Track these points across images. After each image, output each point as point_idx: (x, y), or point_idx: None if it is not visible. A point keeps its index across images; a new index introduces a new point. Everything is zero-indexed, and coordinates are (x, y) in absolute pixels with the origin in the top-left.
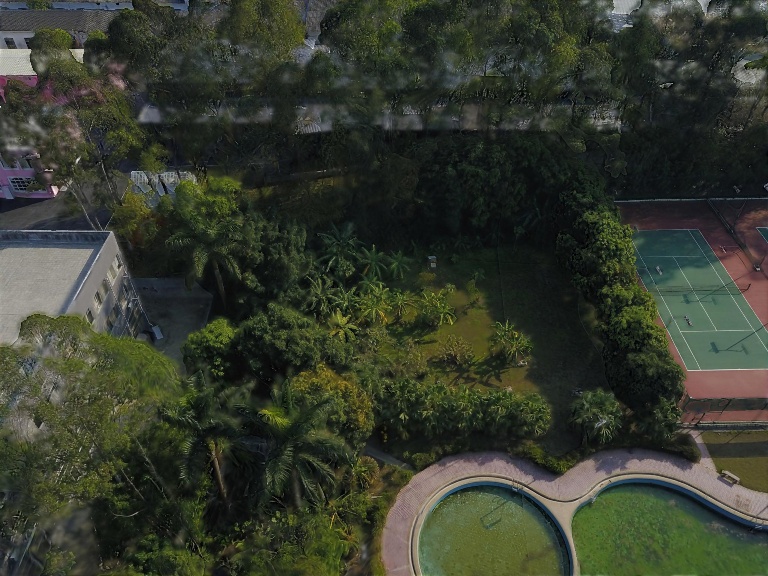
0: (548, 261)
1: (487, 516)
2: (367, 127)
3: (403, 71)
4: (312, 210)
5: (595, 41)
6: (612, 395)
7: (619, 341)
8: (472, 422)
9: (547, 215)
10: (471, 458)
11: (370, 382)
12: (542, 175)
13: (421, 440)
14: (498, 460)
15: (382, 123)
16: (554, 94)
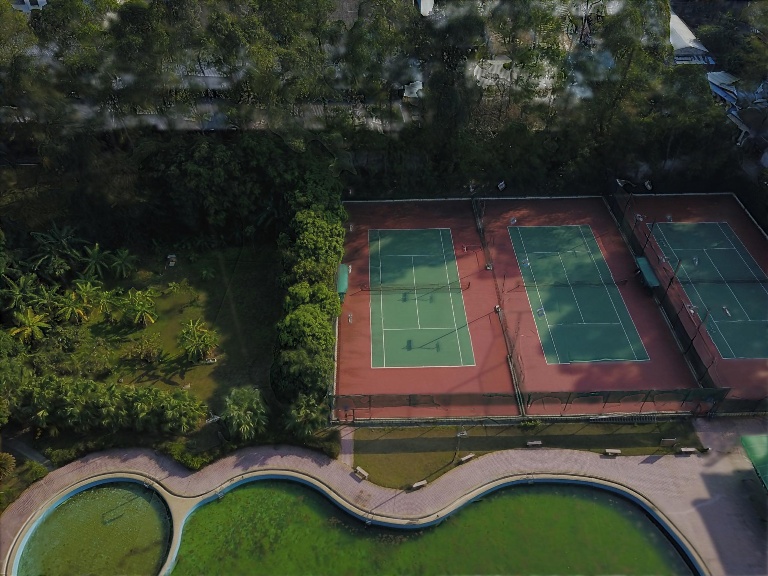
0: None
1: (110, 512)
2: (67, 127)
3: (91, 71)
4: (32, 209)
5: (322, 42)
6: (256, 392)
7: (280, 338)
8: (118, 419)
9: None
10: (116, 454)
11: (3, 379)
12: (269, 174)
13: (74, 437)
14: (142, 456)
15: (102, 123)
16: None
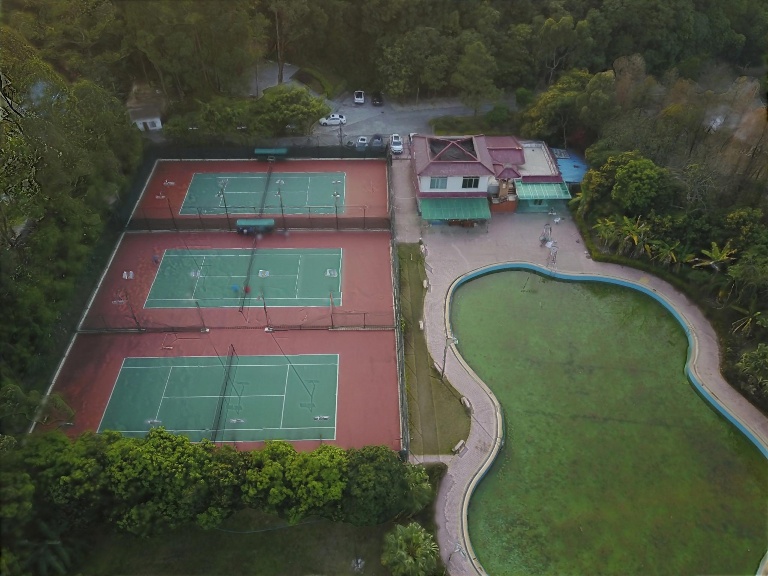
0: (121, 551)
1: None
2: None
3: None
4: None
5: None
6: (400, 527)
7: (335, 497)
8: None
9: (61, 530)
10: None
11: None
12: (10, 517)
13: None
14: None
15: None
16: None
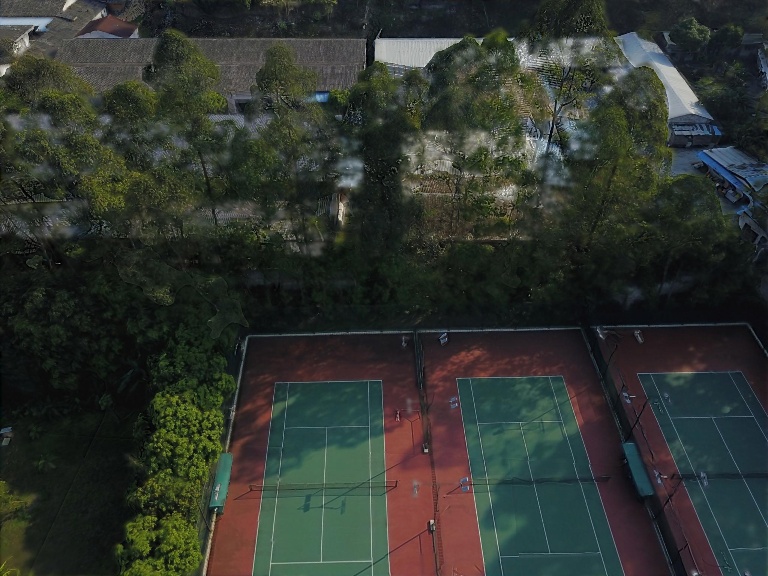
0: None
1: None
2: None
3: None
4: None
5: None
6: None
7: None
8: None
9: None
10: None
11: None
12: None
13: None
14: None
15: None
16: (166, 215)
